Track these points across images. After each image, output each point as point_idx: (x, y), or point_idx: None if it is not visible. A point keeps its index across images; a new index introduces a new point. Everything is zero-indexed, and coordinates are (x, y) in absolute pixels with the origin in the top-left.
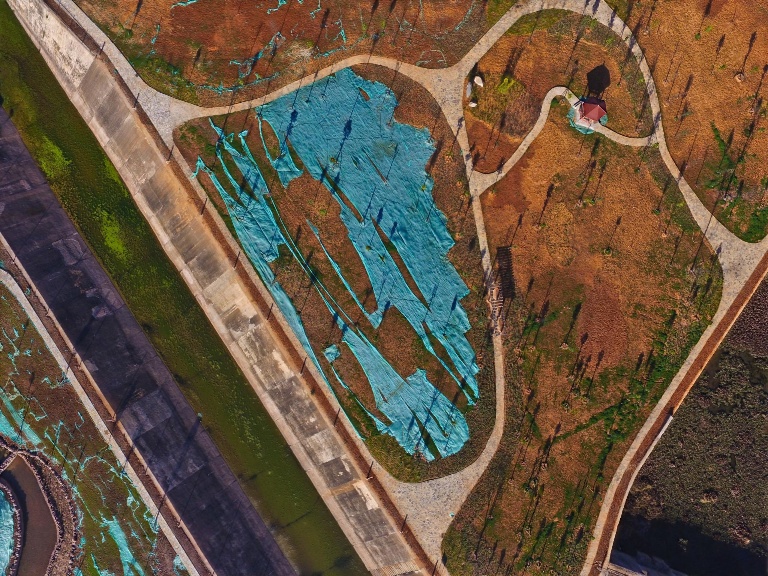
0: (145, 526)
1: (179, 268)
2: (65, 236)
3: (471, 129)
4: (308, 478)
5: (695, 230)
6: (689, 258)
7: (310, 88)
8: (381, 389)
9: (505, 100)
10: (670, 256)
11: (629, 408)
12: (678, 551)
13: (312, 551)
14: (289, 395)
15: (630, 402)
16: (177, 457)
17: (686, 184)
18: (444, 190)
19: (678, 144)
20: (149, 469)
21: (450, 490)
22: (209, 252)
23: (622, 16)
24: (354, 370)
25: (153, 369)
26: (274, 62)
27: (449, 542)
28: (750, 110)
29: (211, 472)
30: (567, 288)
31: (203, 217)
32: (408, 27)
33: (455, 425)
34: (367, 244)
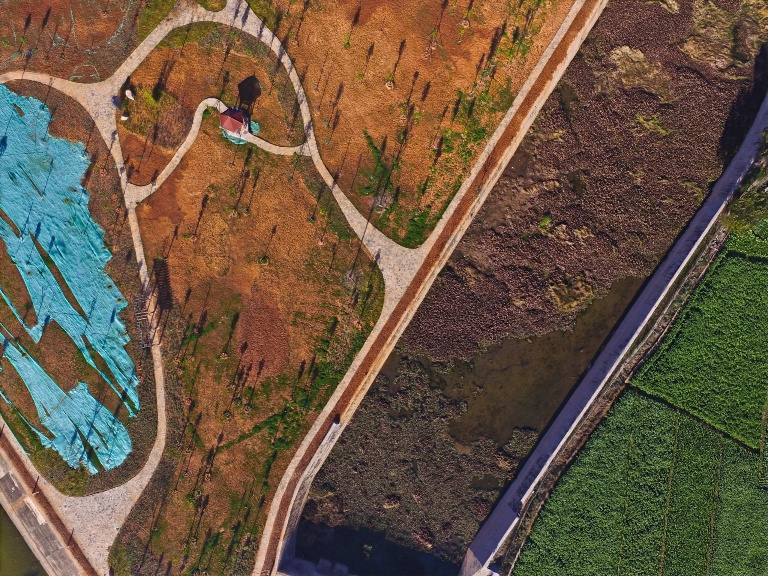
0: None
1: None
2: None
3: (125, 142)
4: None
5: (352, 237)
6: (347, 265)
7: None
8: (44, 403)
9: (157, 113)
10: (328, 263)
11: (293, 416)
12: (362, 557)
13: None
14: None
15: (294, 410)
16: None
17: (340, 192)
18: (100, 203)
19: (331, 152)
20: None
21: (114, 503)
22: None
23: (271, 27)
24: (16, 385)
25: None
26: None
27: (115, 555)
28: (402, 117)
29: None
30: (225, 298)
31: None
32: (61, 42)
33: (117, 438)
34: (26, 259)
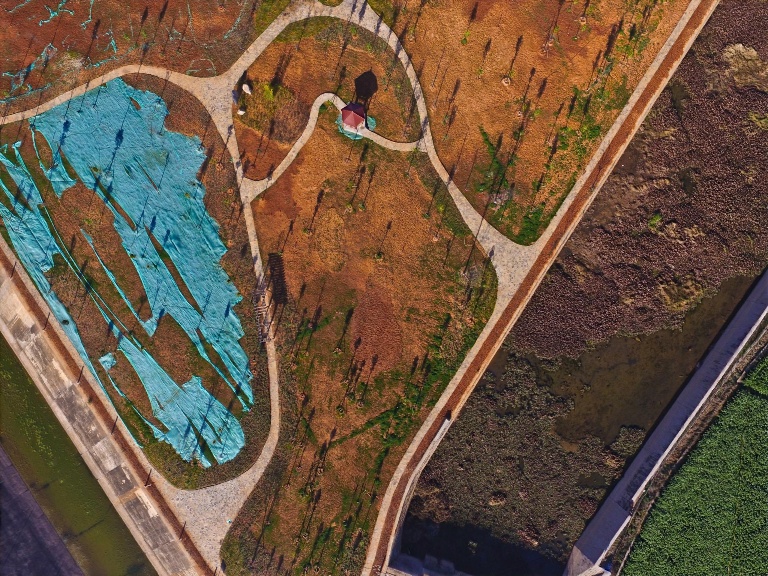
0: None
1: None
2: None
3: (241, 137)
4: (100, 486)
5: (466, 233)
6: (461, 261)
7: (82, 98)
8: (157, 397)
9: (273, 107)
10: (442, 260)
11: (405, 412)
12: (467, 554)
13: (105, 559)
14: (72, 404)
15: (406, 406)
16: None
17: (456, 188)
18: (215, 197)
19: (447, 148)
20: None
21: (227, 497)
22: None
23: (388, 22)
24: (130, 378)
25: None
26: (46, 73)
27: (227, 549)
28: (518, 113)
29: (0, 482)
30: (339, 293)
31: None
32: (178, 36)
33: (230, 431)
34: (141, 252)
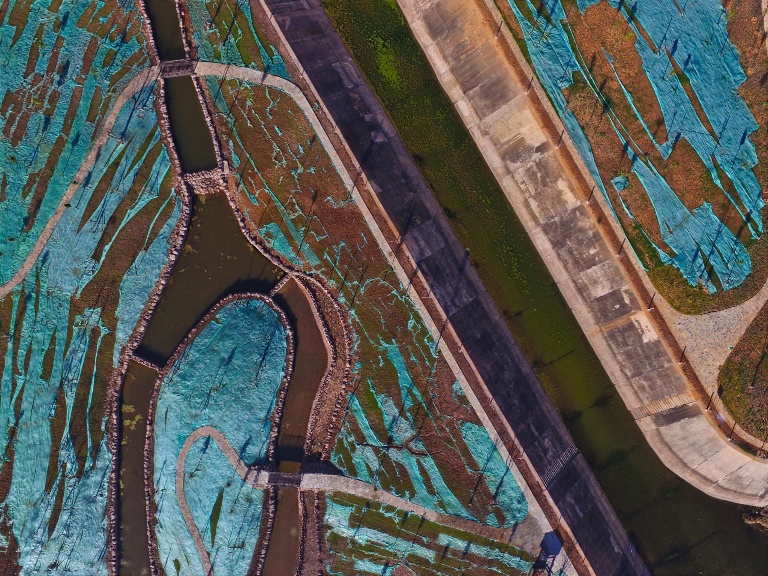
0: (425, 350)
1: (454, 100)
2: (342, 60)
3: None
4: (573, 316)
5: None
6: None
7: None
8: (667, 220)
9: None
10: None
11: None
12: None
13: (573, 389)
14: (569, 227)
15: None
16: (453, 286)
17: None
18: (739, 25)
19: None
20: (432, 293)
21: (730, 323)
22: (499, 78)
23: None
24: (641, 200)
25: (426, 199)
26: None
27: (726, 374)
28: None
29: (481, 305)
30: None
31: (498, 40)
32: None
33: (738, 258)
34: (661, 75)
